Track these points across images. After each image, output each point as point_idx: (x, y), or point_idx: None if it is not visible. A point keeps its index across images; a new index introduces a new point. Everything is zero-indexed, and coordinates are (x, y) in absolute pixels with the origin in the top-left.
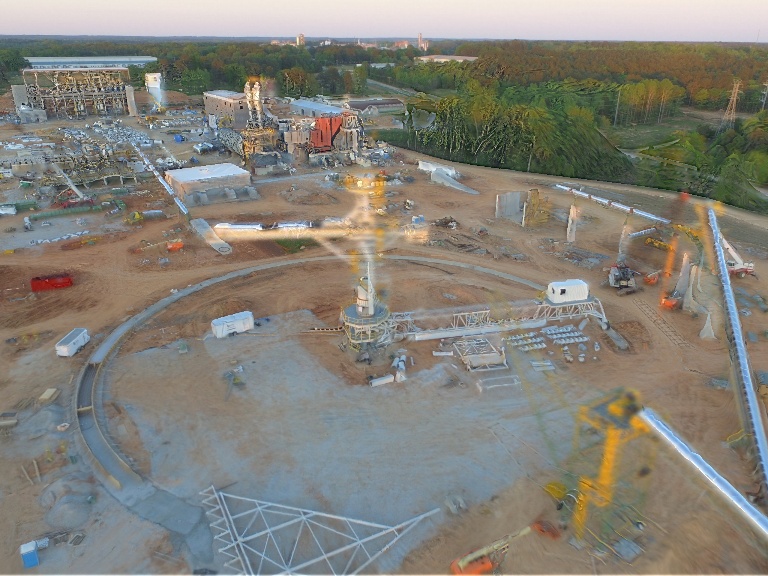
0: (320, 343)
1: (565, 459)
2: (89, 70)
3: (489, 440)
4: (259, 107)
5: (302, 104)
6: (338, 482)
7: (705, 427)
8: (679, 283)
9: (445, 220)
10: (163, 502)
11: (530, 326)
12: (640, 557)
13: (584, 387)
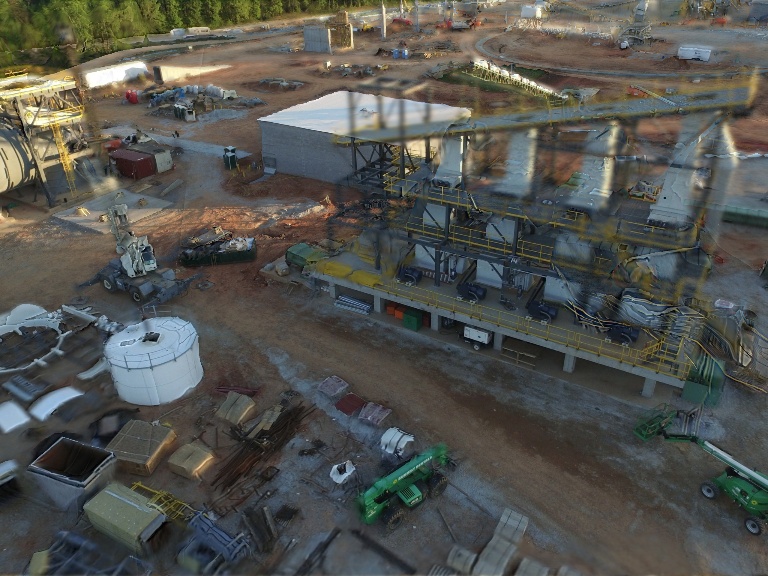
0: None
1: None
2: None
3: None
4: None
5: None
6: None
7: None
8: None
9: (388, 51)
10: None
11: None
12: None
13: None
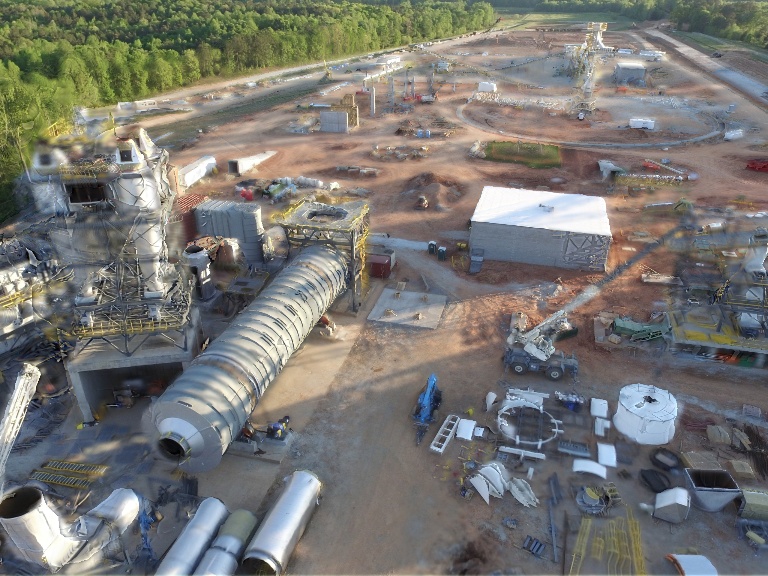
0: None
1: None
2: None
3: None
4: None
5: None
6: None
7: None
8: None
9: None
10: None
11: None
12: None
13: None
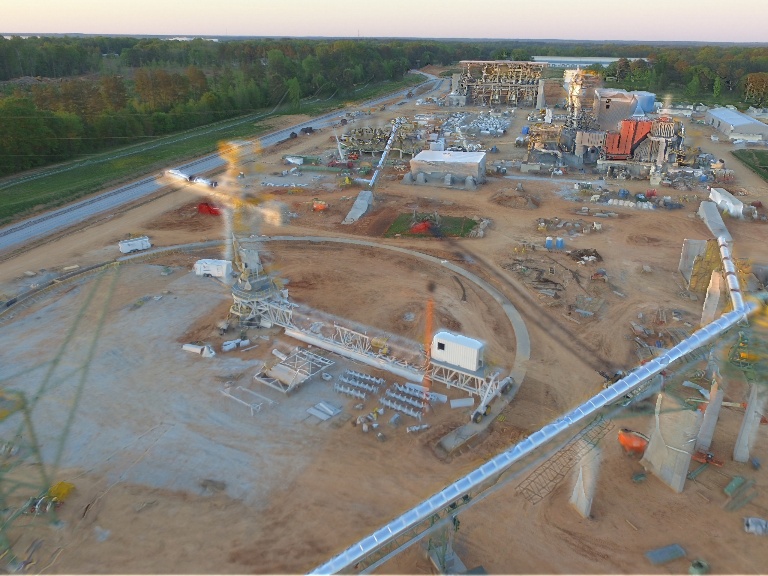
0: None
1: (136, 483)
2: (512, 63)
3: (138, 430)
4: (578, 103)
5: (716, 112)
6: (23, 389)
7: (298, 568)
8: (701, 427)
9: (584, 251)
10: None
11: (406, 375)
12: None
13: (304, 450)
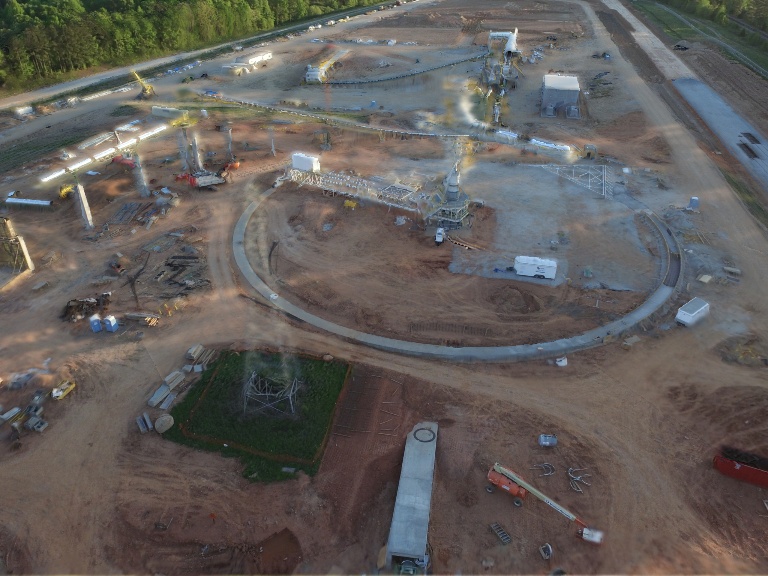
0: (480, 236)
1: None
2: None
3: None
4: None
5: None
6: None
7: (374, 146)
8: None
9: (84, 305)
10: (632, 204)
11: None
12: (474, 141)
13: (383, 167)
